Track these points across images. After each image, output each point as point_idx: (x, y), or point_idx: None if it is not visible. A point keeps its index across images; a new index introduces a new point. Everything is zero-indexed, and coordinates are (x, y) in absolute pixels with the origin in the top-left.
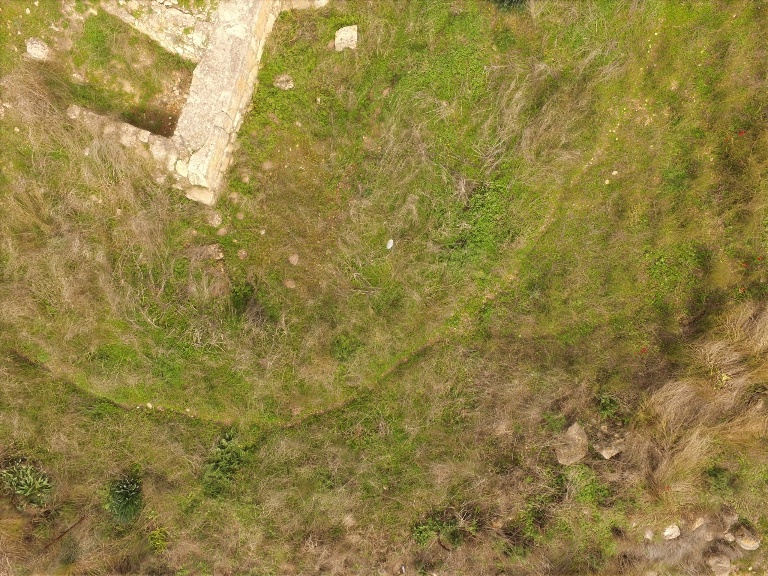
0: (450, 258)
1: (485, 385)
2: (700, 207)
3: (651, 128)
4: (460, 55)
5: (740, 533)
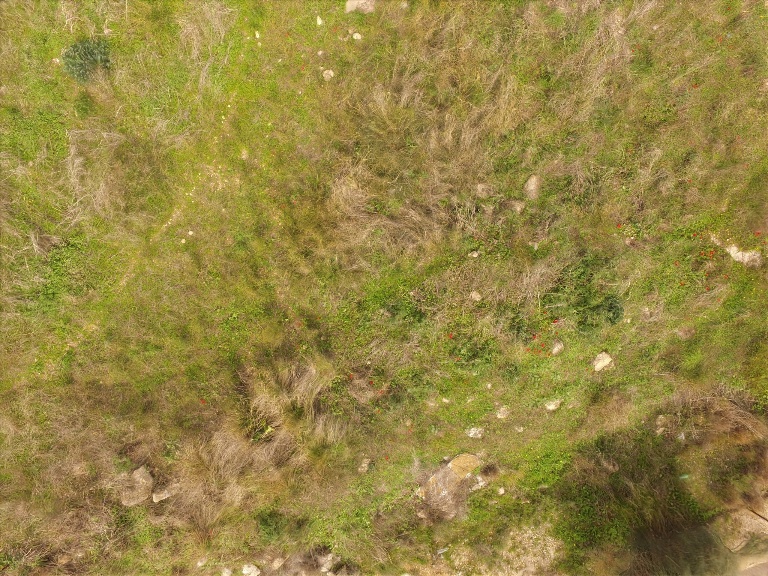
0: (27, 308)
1: (58, 428)
2: (268, 268)
3: (222, 193)
4: (44, 119)
5: (337, 572)
